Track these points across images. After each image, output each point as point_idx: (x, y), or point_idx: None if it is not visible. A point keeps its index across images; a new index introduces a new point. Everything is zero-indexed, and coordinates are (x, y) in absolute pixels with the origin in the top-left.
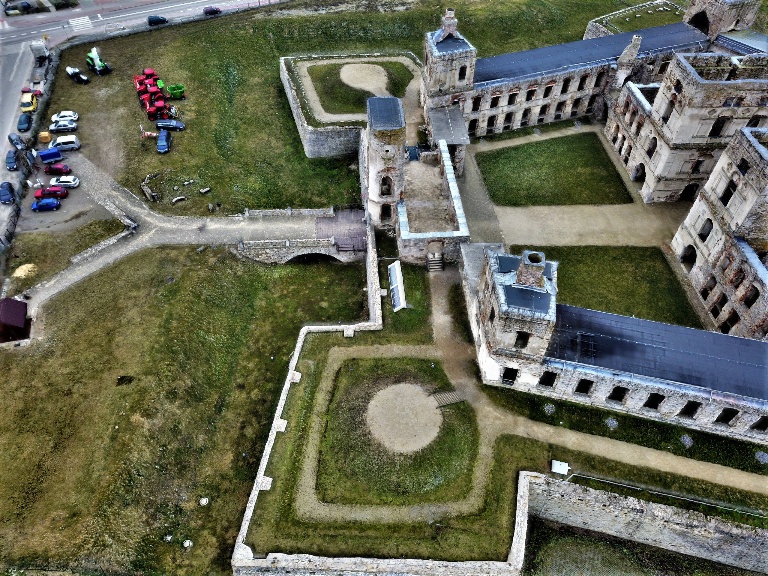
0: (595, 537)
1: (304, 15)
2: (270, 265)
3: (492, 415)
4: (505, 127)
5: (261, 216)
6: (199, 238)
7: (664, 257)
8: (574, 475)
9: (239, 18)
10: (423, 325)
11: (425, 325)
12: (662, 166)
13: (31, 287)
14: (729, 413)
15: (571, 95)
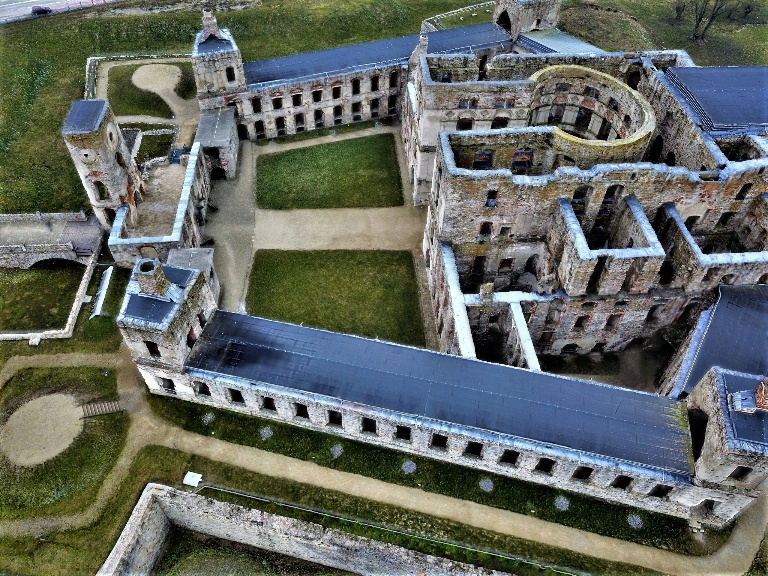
0: (238, 549)
1: (136, 14)
2: (12, 271)
3: (146, 425)
4: (299, 128)
5: (10, 220)
6: None
7: (412, 261)
8: (205, 487)
9: (68, 17)
10: (115, 333)
11: (117, 333)
12: (418, 168)
13: None
14: (371, 423)
15: (365, 96)
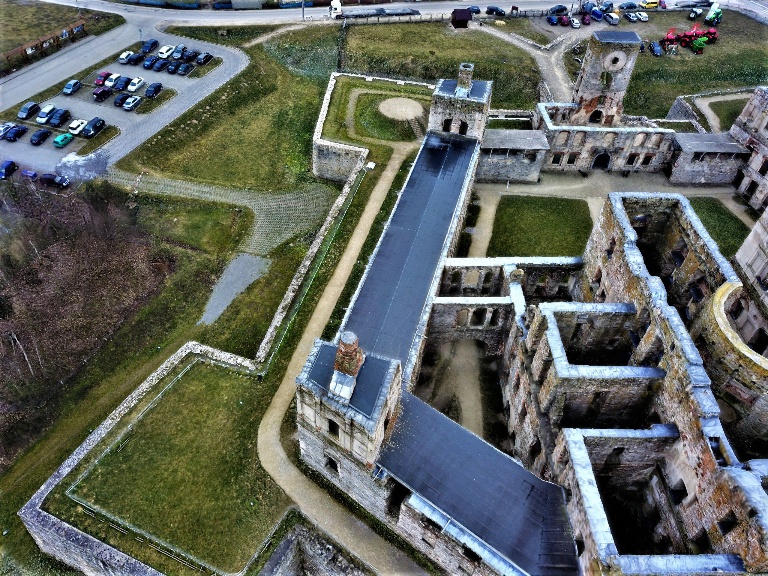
0: None
1: None
2: None
3: (407, 147)
4: None
5: None
6: (545, 70)
7: None
8: (366, 171)
9: None
10: None
11: None
12: None
13: (489, 25)
14: None
15: None
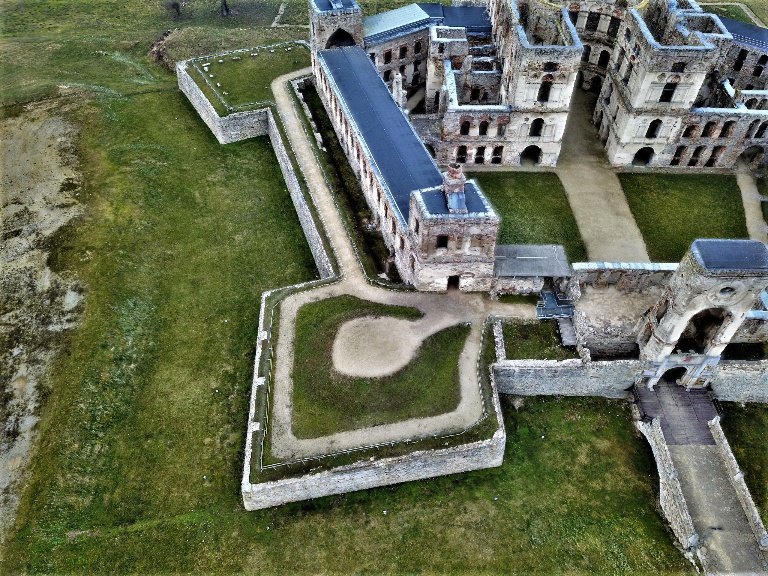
0: None
1: (28, 457)
2: None
3: None
4: None
5: None
6: None
7: (629, 173)
8: None
9: None
10: None
11: None
12: (563, 130)
13: None
14: None
15: None
